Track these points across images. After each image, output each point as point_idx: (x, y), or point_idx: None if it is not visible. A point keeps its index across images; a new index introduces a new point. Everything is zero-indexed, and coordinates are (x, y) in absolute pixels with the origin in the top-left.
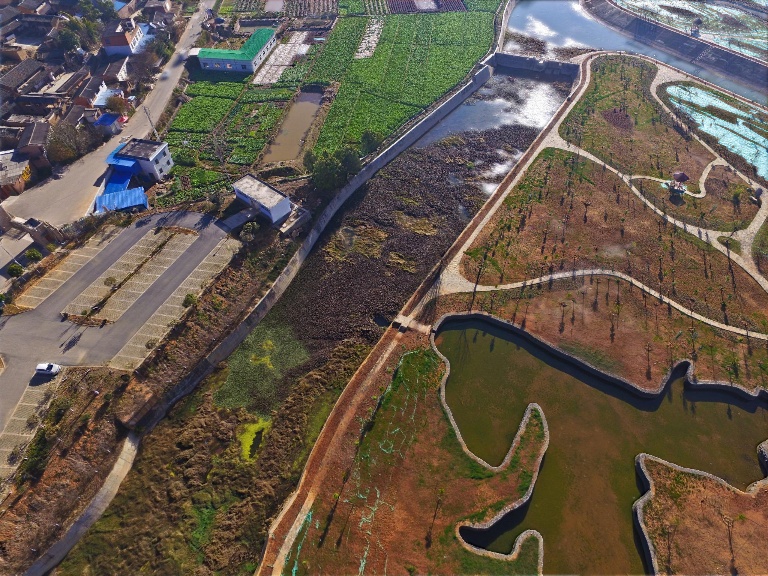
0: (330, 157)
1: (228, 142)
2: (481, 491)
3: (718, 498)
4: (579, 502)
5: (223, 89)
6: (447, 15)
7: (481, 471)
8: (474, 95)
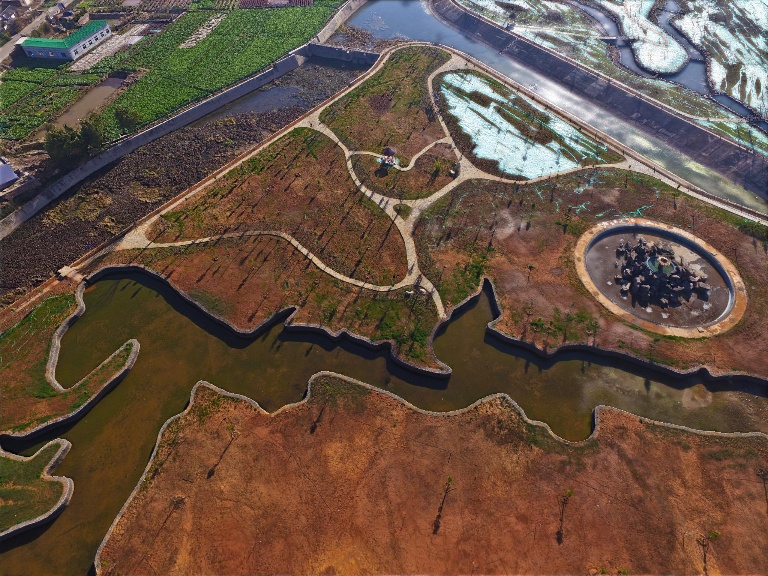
0: (60, 130)
1: (11, 120)
2: (37, 407)
3: (240, 417)
4: (125, 419)
5: (35, 74)
6: (289, 10)
7: (48, 392)
8: (273, 82)
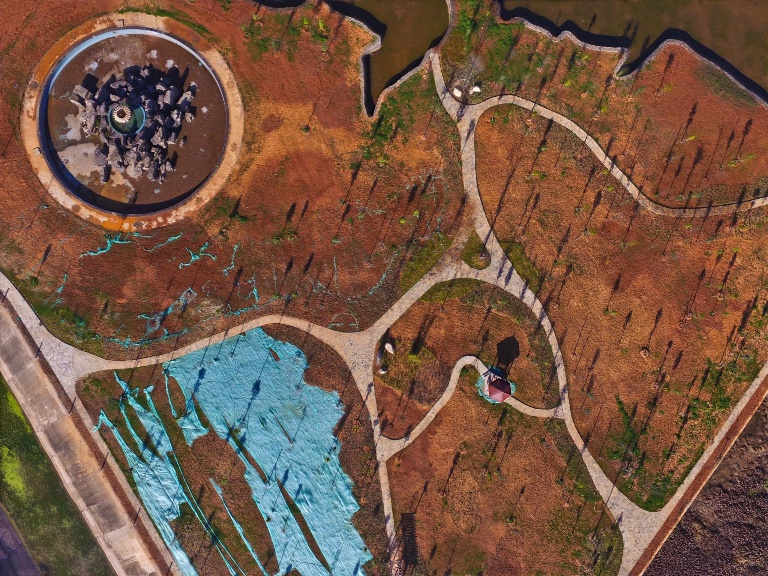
0: None
1: None
2: None
3: None
4: None
5: None
6: None
7: None
8: None
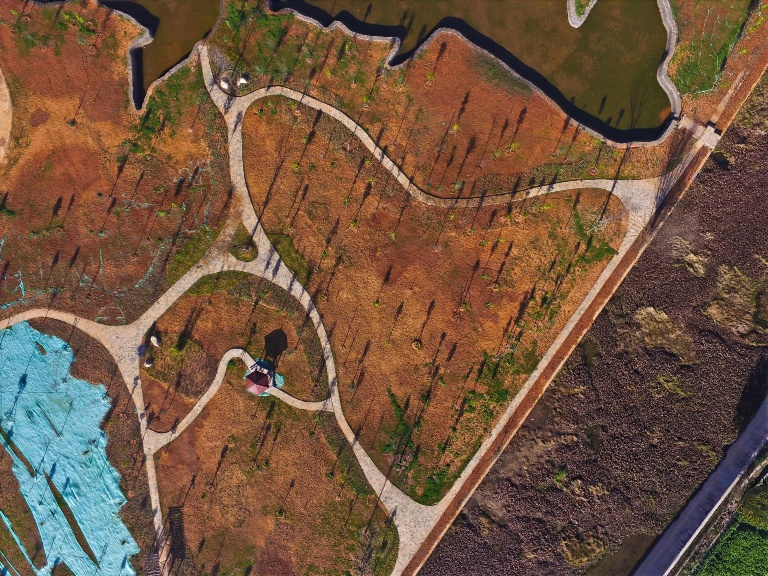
0: None
1: None
2: None
3: None
4: None
5: None
6: None
7: None
8: None
